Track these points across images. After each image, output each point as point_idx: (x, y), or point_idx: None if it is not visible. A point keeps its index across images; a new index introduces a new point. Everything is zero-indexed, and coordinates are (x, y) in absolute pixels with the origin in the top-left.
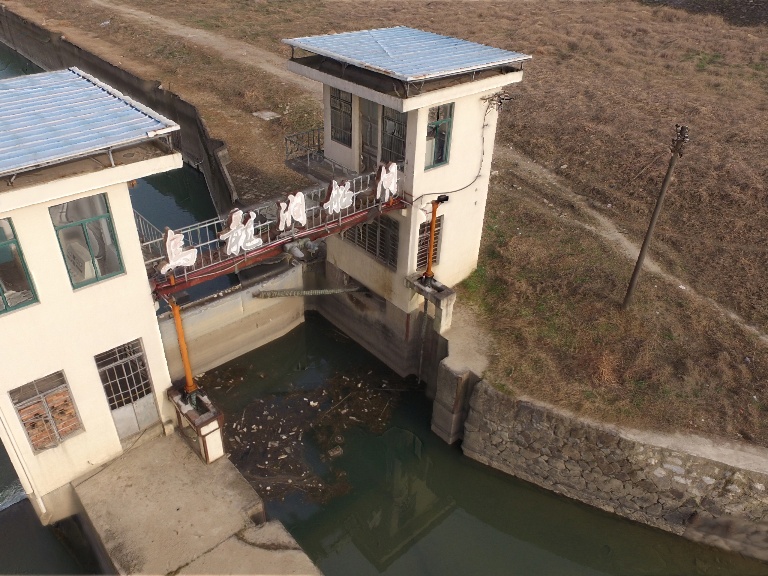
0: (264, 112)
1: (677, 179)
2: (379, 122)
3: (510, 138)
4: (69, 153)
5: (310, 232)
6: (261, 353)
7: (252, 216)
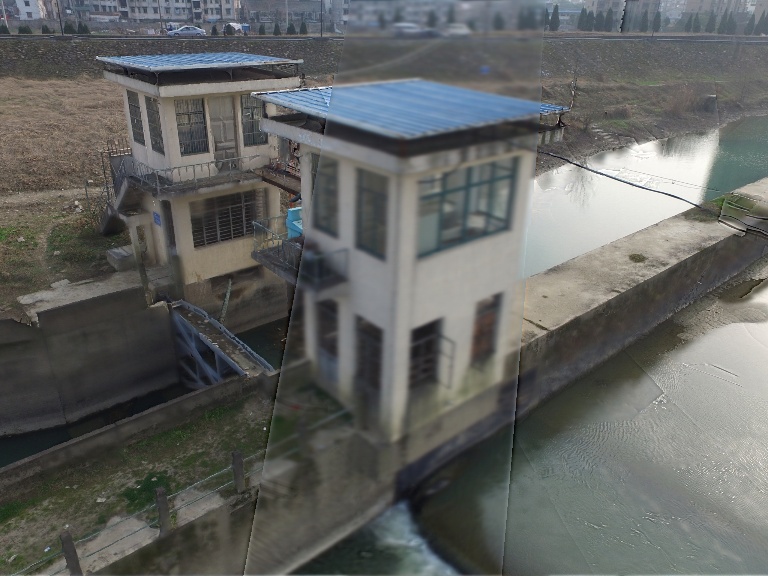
0: None
1: None
2: (239, 115)
3: None
4: None
5: None
6: None
7: None
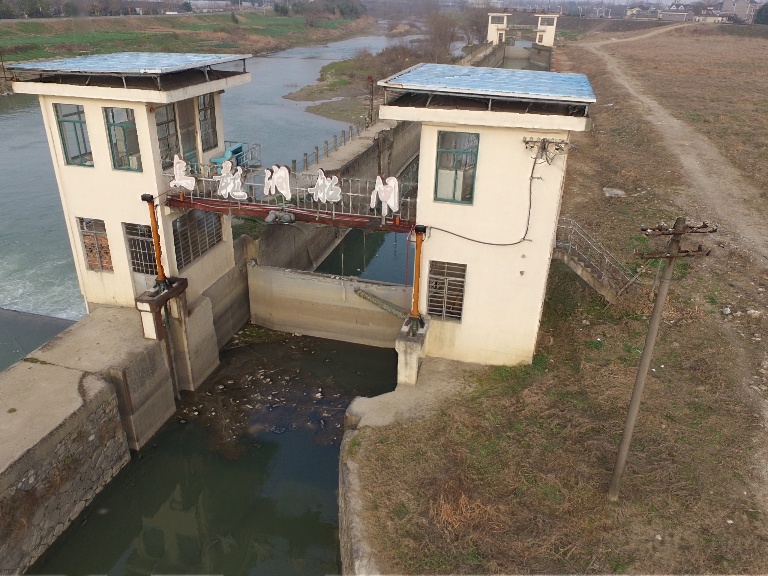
0: (615, 189)
1: None
2: None
3: None
4: (96, 69)
5: (303, 212)
6: (353, 348)
7: (239, 170)
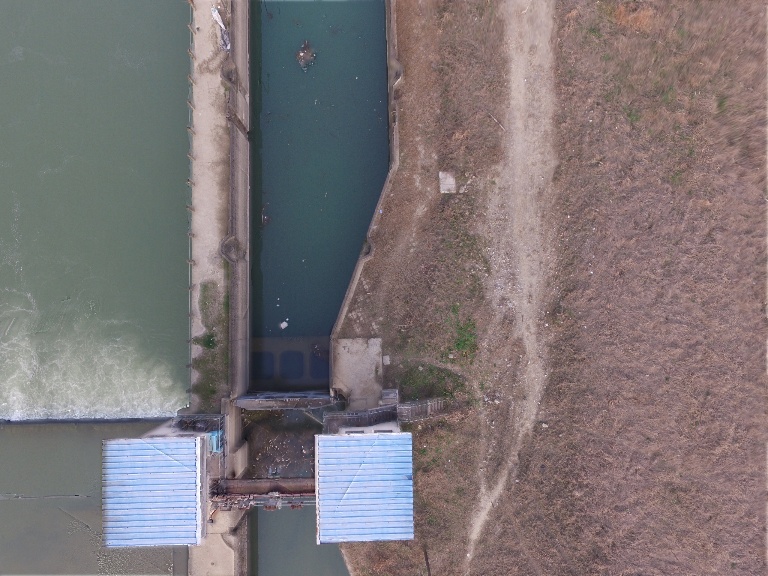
0: (448, 176)
1: (582, 494)
2: None
3: (557, 364)
4: None
5: None
6: None
7: None
